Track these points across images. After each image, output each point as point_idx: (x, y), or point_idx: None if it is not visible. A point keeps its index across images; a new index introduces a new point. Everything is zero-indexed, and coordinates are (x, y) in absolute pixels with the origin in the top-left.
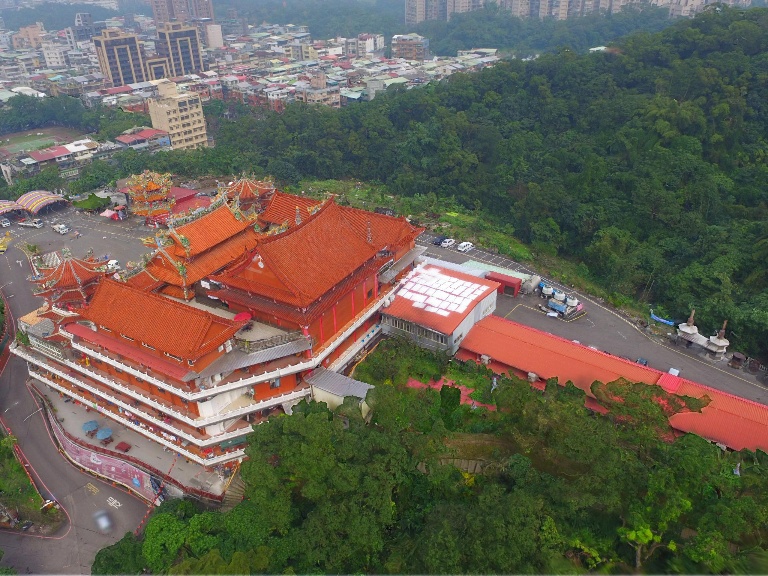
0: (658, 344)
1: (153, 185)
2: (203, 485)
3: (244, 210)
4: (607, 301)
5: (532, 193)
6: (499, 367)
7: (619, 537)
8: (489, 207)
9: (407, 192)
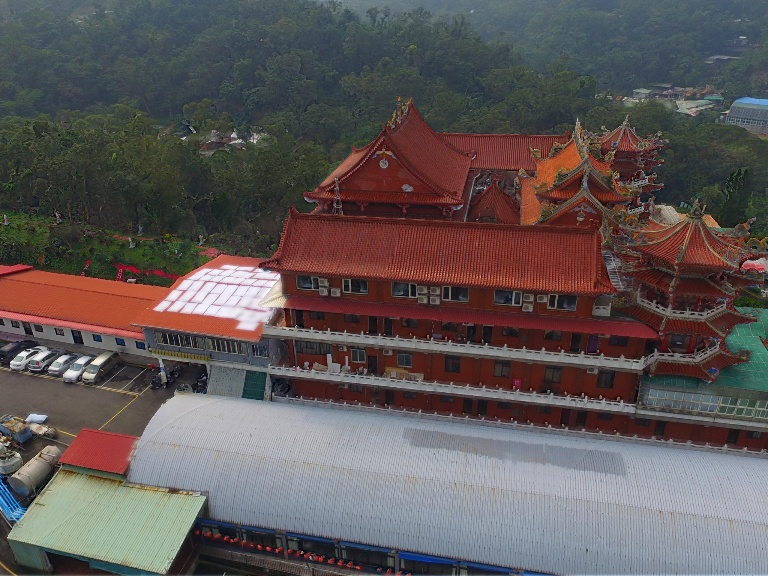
0: None
1: None
2: None
3: None
4: None
5: None
6: None
7: None
8: None
9: None
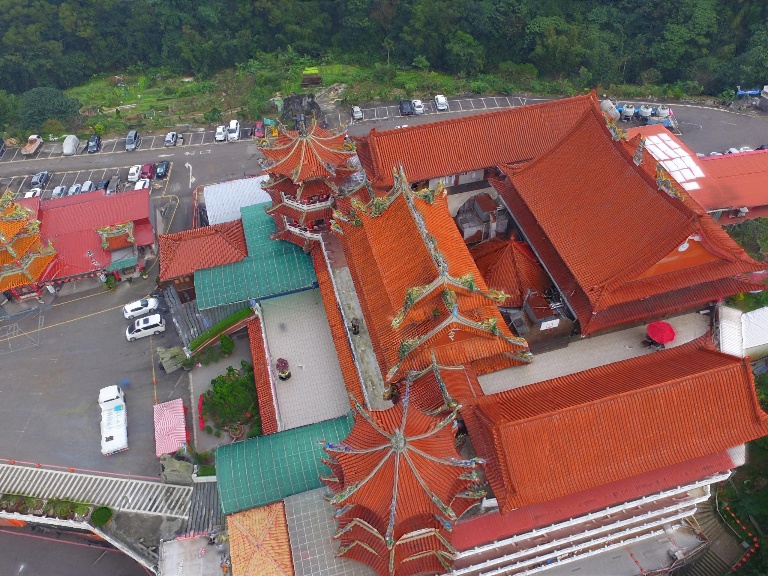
0: (759, 117)
1: (6, 227)
2: (665, 548)
3: (340, 186)
4: None
5: (439, 8)
6: (755, 212)
7: None
8: (338, 45)
9: (209, 65)
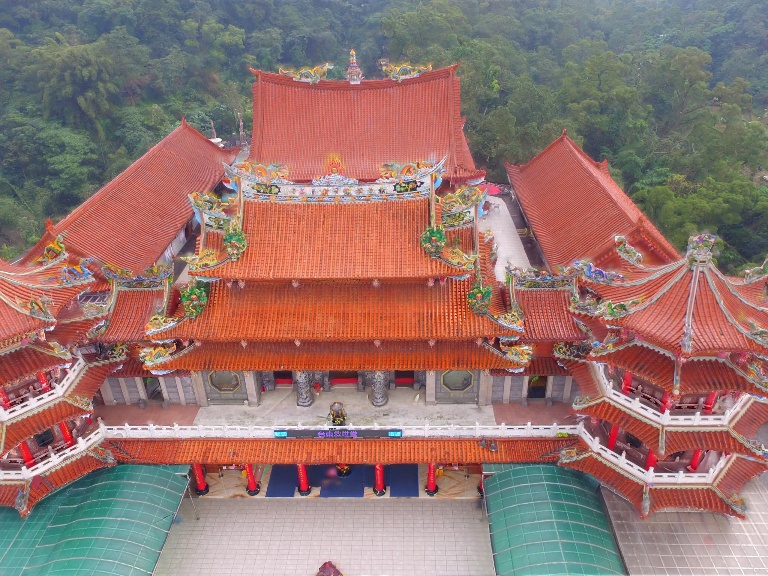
0: None
1: None
2: None
3: None
4: None
5: None
6: None
7: None
8: None
9: None
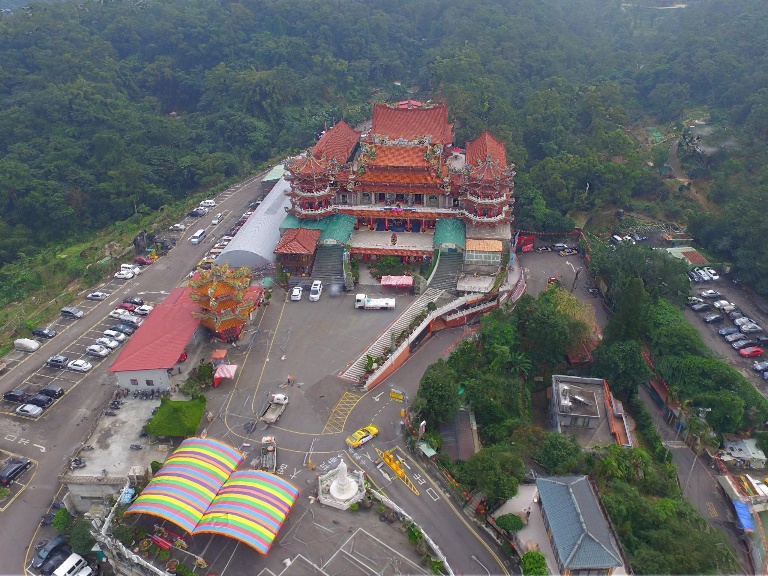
0: None
1: None
2: None
3: None
4: (295, 153)
5: (135, 171)
6: None
7: (486, 111)
8: (49, 240)
9: None
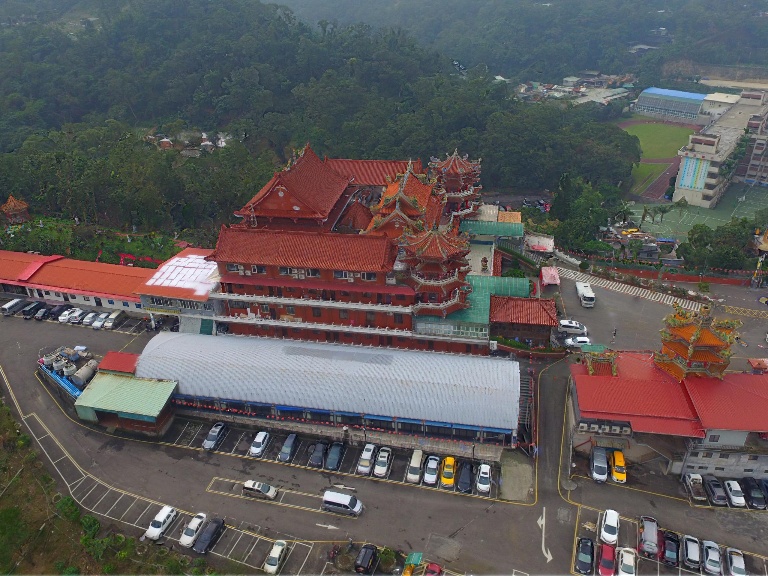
0: None
1: None
2: None
3: None
4: None
5: None
6: None
7: None
8: None
9: None
